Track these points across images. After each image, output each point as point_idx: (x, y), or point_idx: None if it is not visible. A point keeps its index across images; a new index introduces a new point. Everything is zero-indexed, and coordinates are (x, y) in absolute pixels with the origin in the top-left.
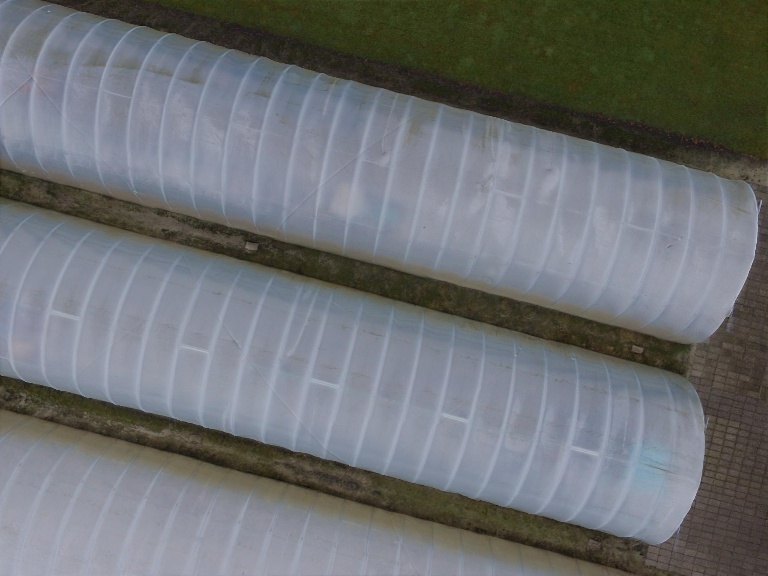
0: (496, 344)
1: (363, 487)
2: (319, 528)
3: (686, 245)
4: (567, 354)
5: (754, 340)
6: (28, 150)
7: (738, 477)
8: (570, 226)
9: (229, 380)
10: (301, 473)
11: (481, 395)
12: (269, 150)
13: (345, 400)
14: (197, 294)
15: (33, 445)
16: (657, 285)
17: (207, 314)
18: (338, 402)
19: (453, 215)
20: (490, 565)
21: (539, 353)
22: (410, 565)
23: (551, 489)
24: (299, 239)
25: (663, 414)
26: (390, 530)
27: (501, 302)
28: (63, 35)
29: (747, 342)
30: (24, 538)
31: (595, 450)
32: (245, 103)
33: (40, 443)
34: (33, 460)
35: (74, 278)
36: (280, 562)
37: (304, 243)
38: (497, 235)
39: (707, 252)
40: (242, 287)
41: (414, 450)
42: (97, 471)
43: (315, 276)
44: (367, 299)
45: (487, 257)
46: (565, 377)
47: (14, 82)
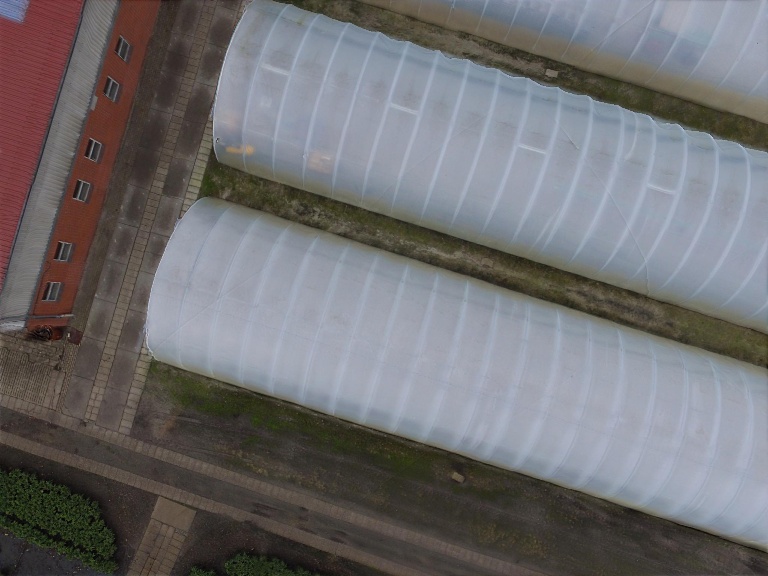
0: None
1: (654, 318)
2: (631, 345)
3: None
4: None
5: None
6: None
7: None
8: None
9: (564, 181)
10: (592, 302)
11: None
12: None
13: (681, 206)
14: (529, 98)
15: (345, 248)
16: None
17: (542, 116)
18: (674, 208)
19: None
20: None
21: None
22: (729, 382)
23: None
24: (605, 65)
25: None
26: (695, 355)
27: None
28: None
29: None
30: (354, 329)
31: None
32: None
33: (350, 248)
34: (350, 260)
35: (411, 74)
36: (606, 368)
37: (606, 72)
38: None
39: None
40: (567, 98)
41: (744, 262)
42: (409, 277)
43: None
44: None
45: None
46: None
47: None
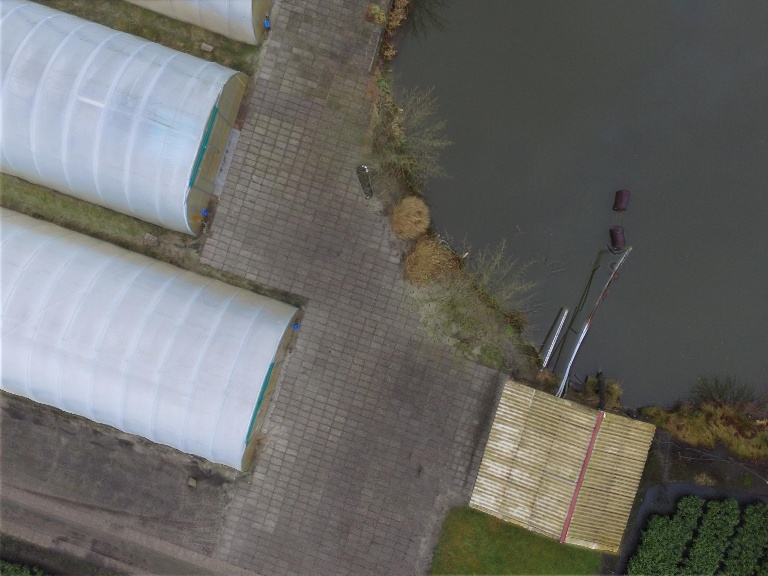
0: (42, 13)
1: None
2: None
3: None
4: (116, 31)
5: (324, 47)
6: None
7: (298, 182)
8: None
9: None
10: None
11: None
12: None
13: None
14: None
15: None
16: None
17: None
18: None
19: None
20: (17, 230)
21: (82, 23)
22: None
23: (61, 142)
24: None
25: (182, 79)
26: None
27: None
28: None
29: (317, 49)
30: None
31: (101, 101)
32: None
33: None
34: None
35: None
36: None
37: None
38: None
39: None
40: None
41: None
42: None
43: None
44: None
45: None
46: (93, 39)
47: None
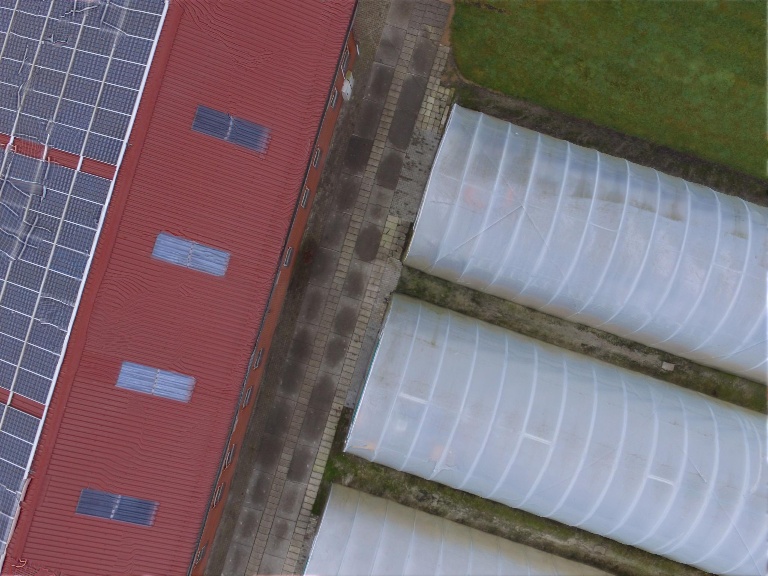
0: None
1: None
2: None
3: None
4: None
5: None
6: (486, 267)
7: None
8: None
9: (691, 512)
10: None
11: None
12: (747, 292)
13: None
14: (657, 424)
15: (470, 554)
16: None
17: (671, 446)
18: None
19: None
20: None
21: None
22: None
23: None
24: (722, 365)
25: None
26: None
27: None
28: (546, 163)
29: None
30: None
31: None
32: (726, 244)
33: (474, 552)
34: (476, 571)
35: (543, 402)
36: None
37: (722, 367)
38: None
39: None
40: (692, 417)
41: None
42: None
43: (729, 400)
44: None
45: None
46: None
47: (504, 209)
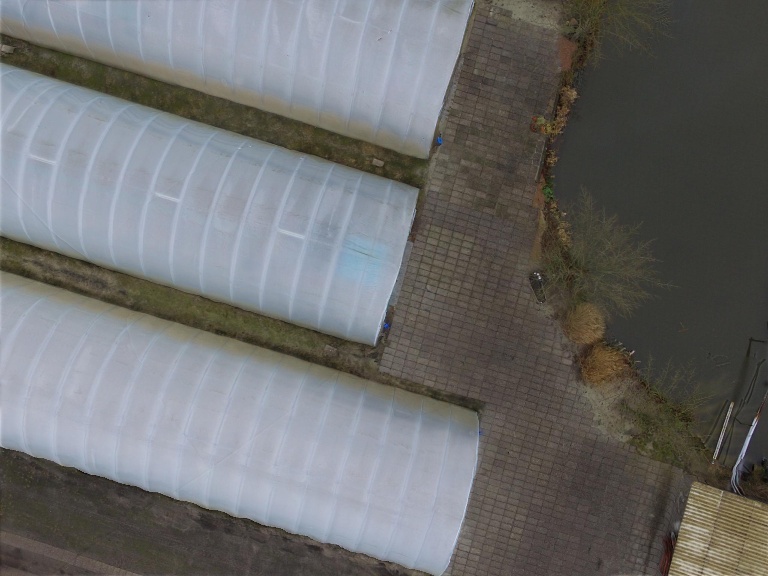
0: (227, 141)
1: (108, 287)
2: (47, 311)
3: (395, 38)
4: (298, 155)
5: (492, 158)
6: None
7: (471, 290)
8: (285, 16)
9: None
10: (48, 271)
11: (193, 176)
12: None
13: (61, 176)
14: None
15: None
16: (371, 80)
17: None
18: (54, 178)
19: (173, 2)
20: (213, 353)
21: (267, 151)
22: (128, 345)
23: (262, 272)
24: (50, 40)
25: (374, 205)
26: (122, 320)
27: (248, 112)
28: None
29: (485, 160)
30: None
31: (301, 233)
32: None
33: None
34: None
35: None
36: None
37: (57, 47)
38: (217, 24)
39: (415, 46)
40: None
41: (130, 230)
42: None
43: (68, 80)
44: (112, 100)
45: (212, 50)
46: (284, 169)
47: None
